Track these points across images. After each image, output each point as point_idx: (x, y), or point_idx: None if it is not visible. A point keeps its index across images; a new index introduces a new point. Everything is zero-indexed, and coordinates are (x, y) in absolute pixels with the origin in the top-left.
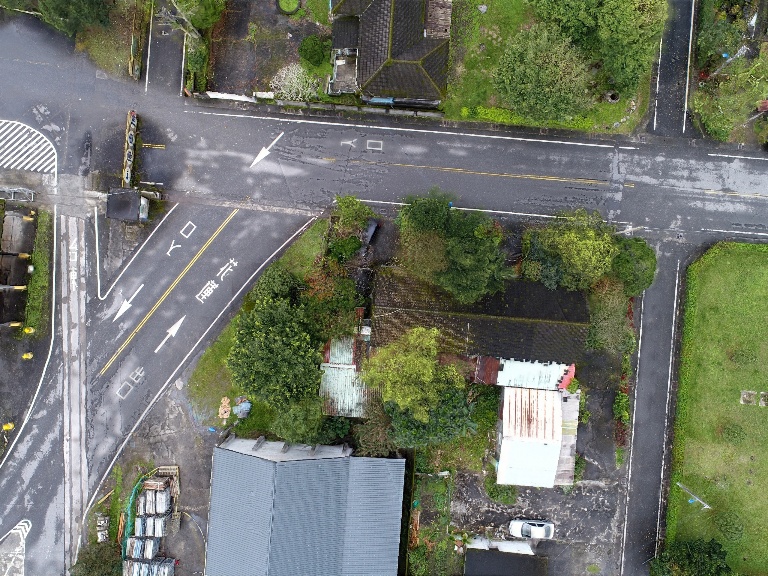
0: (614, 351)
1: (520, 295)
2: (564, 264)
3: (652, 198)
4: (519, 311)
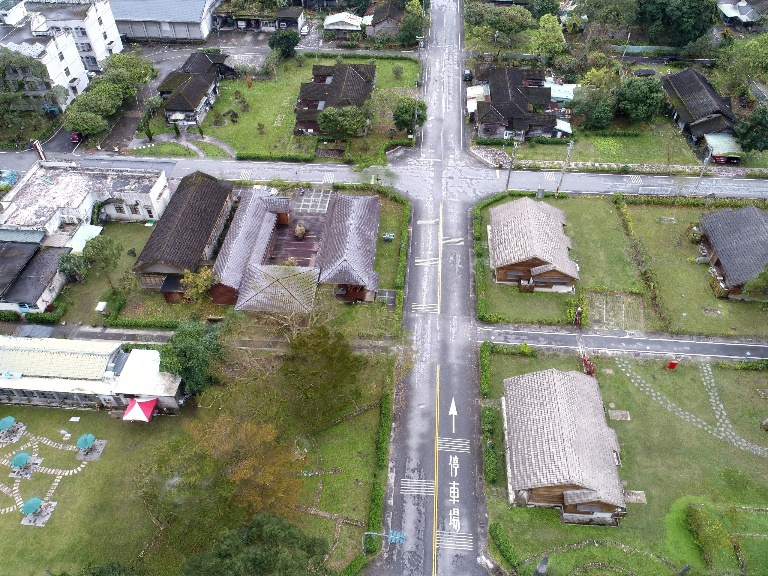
0: (376, 36)
1: (398, 12)
2: (410, 14)
3: (439, 52)
4: (392, 8)
